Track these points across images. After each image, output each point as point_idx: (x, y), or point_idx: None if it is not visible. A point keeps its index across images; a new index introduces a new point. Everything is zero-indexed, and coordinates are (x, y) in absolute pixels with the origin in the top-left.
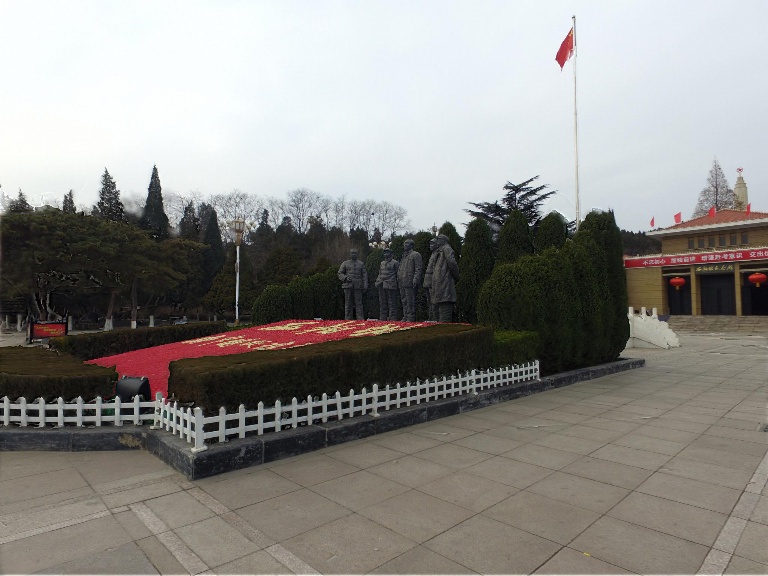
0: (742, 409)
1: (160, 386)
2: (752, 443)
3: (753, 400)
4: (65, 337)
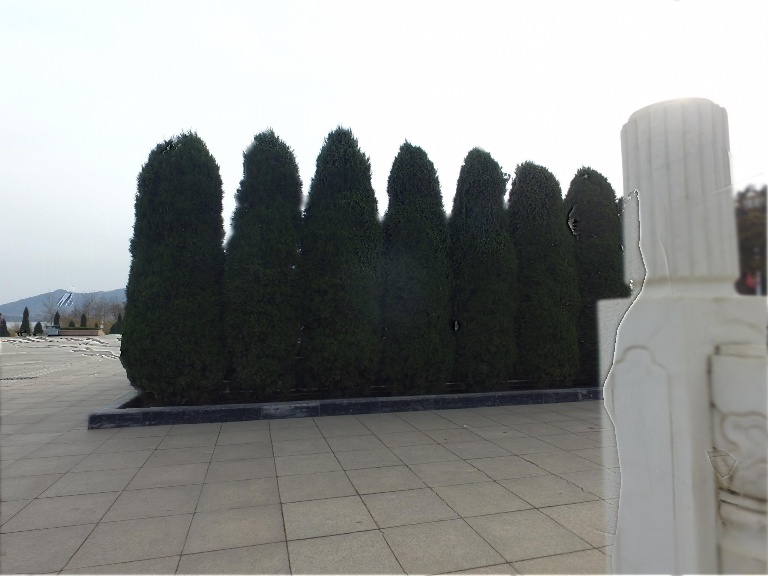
0: (30, 383)
1: None
2: (52, 373)
3: (5, 390)
4: None
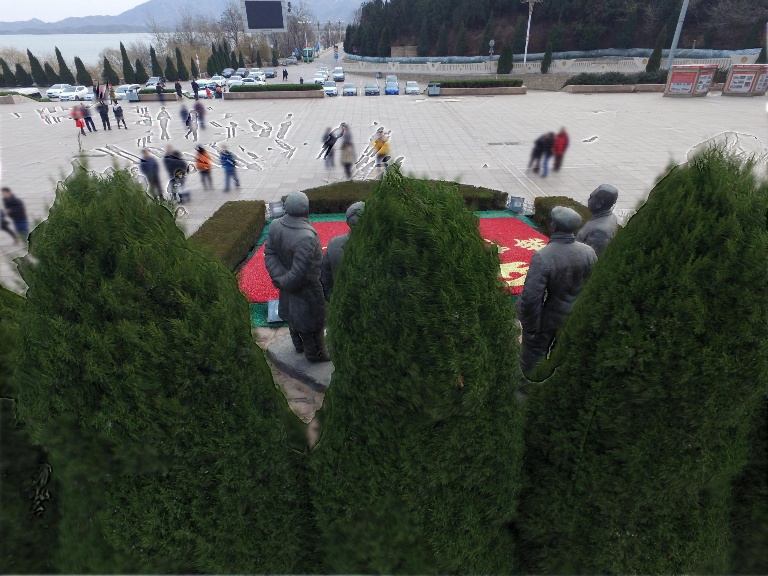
0: None
1: (337, 224)
2: None
3: None
4: (544, 198)
